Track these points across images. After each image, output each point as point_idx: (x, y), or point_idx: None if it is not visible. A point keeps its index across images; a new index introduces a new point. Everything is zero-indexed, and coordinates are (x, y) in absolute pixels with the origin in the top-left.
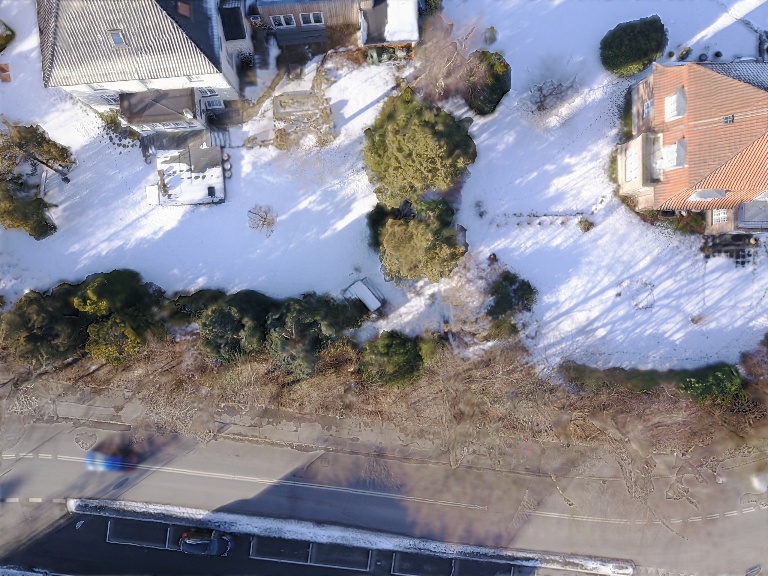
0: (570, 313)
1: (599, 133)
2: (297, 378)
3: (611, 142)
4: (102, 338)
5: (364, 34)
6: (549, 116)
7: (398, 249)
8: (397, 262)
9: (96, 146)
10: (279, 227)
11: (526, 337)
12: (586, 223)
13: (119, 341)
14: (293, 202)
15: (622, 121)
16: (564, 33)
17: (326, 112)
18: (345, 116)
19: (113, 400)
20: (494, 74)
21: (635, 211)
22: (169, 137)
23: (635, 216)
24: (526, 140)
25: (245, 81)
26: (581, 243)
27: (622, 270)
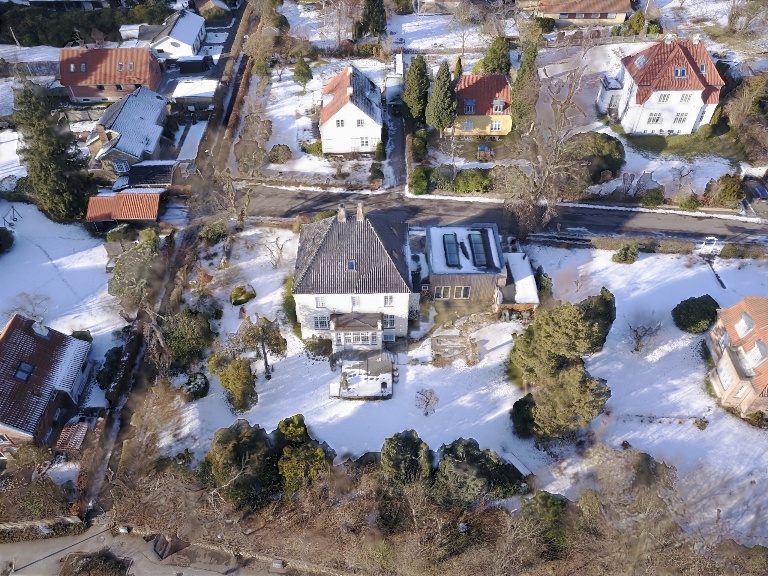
0: (712, 495)
1: (690, 367)
2: (449, 551)
3: (702, 372)
4: (294, 457)
5: (500, 299)
6: (646, 355)
7: (553, 391)
8: (551, 409)
9: (296, 359)
10: (436, 416)
11: (676, 513)
12: (701, 420)
13: (308, 460)
14: (448, 400)
15: (705, 360)
16: (642, 311)
17: (473, 345)
18: (487, 349)
19: (257, 572)
20: (603, 303)
21: (741, 418)
22: (354, 353)
23: (743, 421)
24: (632, 368)
25: (411, 329)
26: (702, 438)
27: (748, 461)
